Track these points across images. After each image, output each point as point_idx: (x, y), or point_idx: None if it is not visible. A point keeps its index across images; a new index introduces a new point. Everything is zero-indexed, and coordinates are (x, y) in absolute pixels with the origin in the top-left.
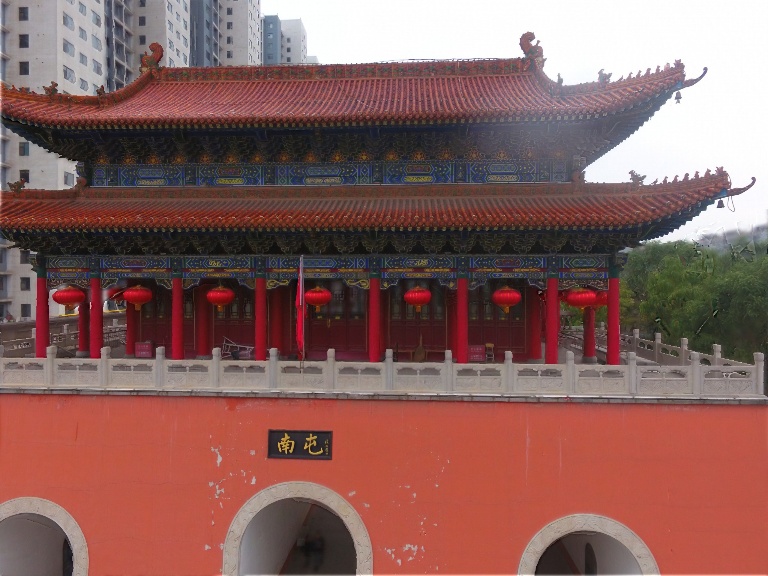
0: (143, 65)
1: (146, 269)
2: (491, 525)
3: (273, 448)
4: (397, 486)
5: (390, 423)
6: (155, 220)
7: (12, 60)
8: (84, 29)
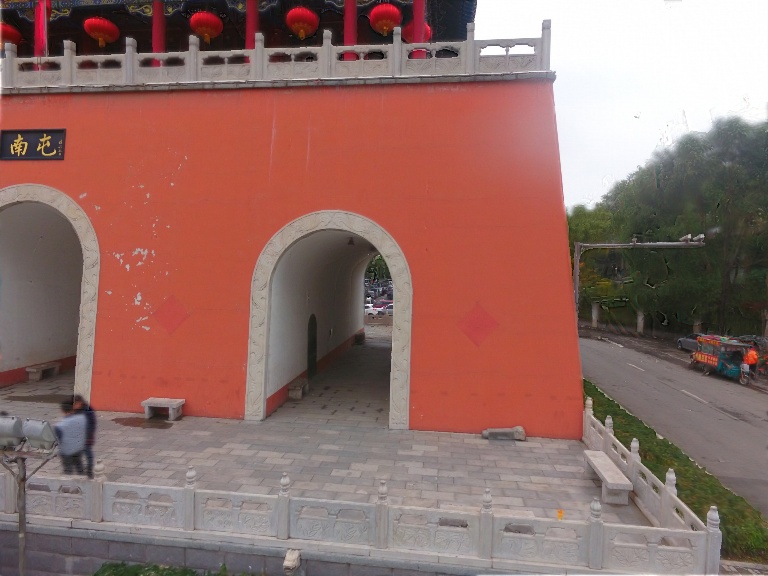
0: None
1: None
2: (228, 226)
3: (5, 150)
4: (130, 186)
5: (127, 118)
6: None
7: None
8: None
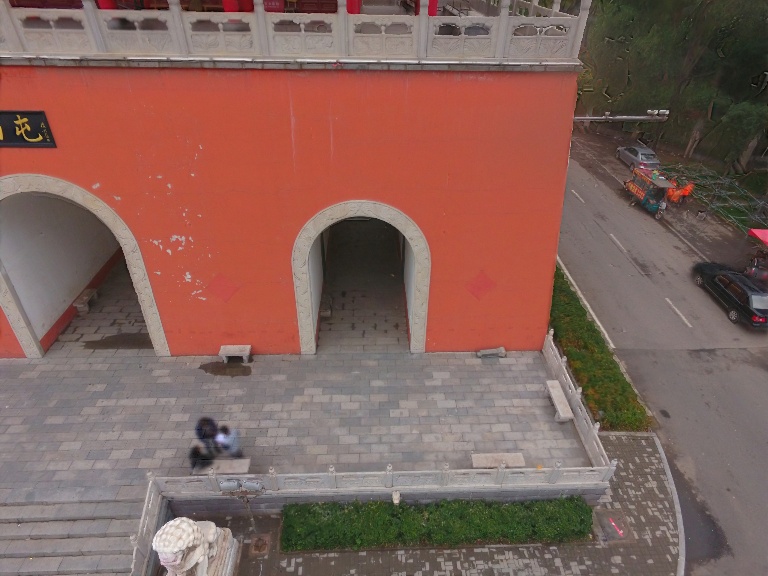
0: None
1: None
2: (260, 214)
3: None
4: (146, 176)
5: (116, 100)
6: None
7: None
8: None
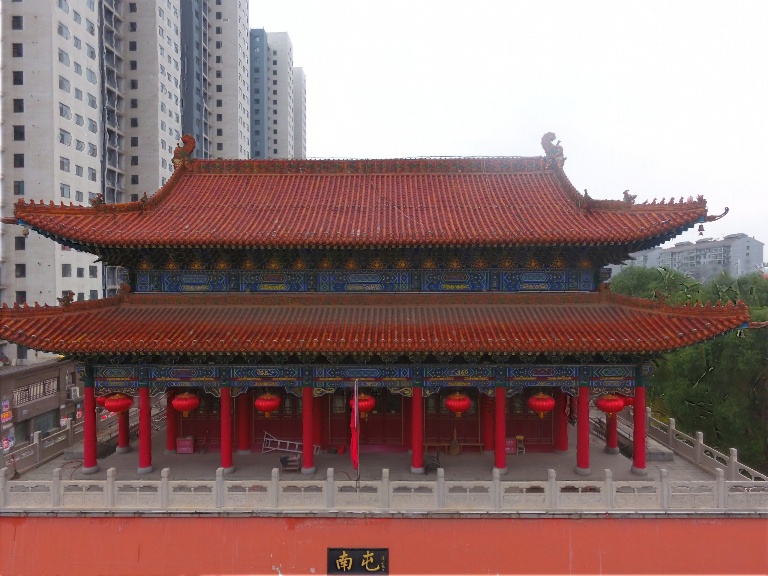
0: (175, 156)
1: (194, 378)
2: None
3: (332, 565)
4: None
5: (443, 540)
6: (212, 344)
7: (6, 97)
8: (79, 63)
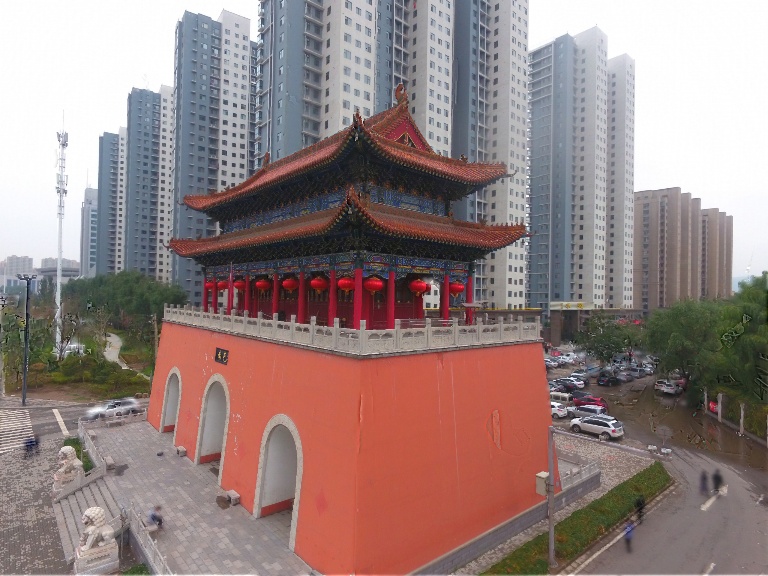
0: None
1: None
2: None
3: None
4: None
5: (241, 349)
6: None
7: None
8: None
